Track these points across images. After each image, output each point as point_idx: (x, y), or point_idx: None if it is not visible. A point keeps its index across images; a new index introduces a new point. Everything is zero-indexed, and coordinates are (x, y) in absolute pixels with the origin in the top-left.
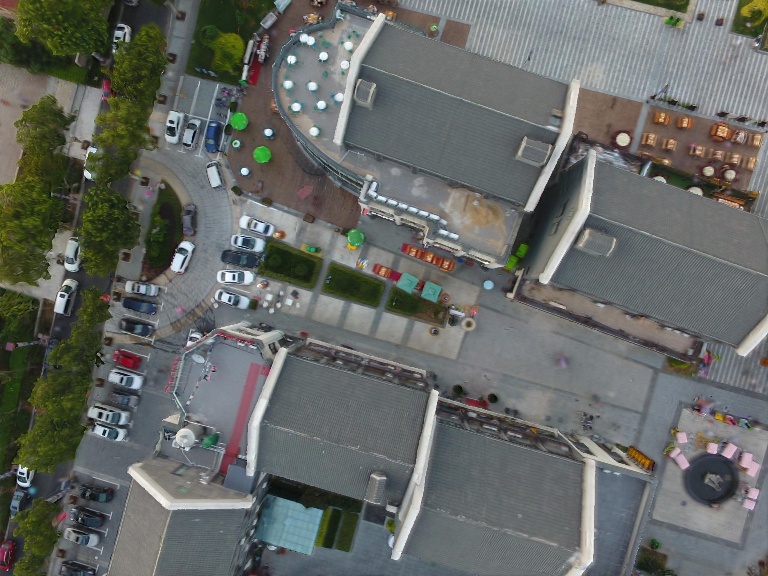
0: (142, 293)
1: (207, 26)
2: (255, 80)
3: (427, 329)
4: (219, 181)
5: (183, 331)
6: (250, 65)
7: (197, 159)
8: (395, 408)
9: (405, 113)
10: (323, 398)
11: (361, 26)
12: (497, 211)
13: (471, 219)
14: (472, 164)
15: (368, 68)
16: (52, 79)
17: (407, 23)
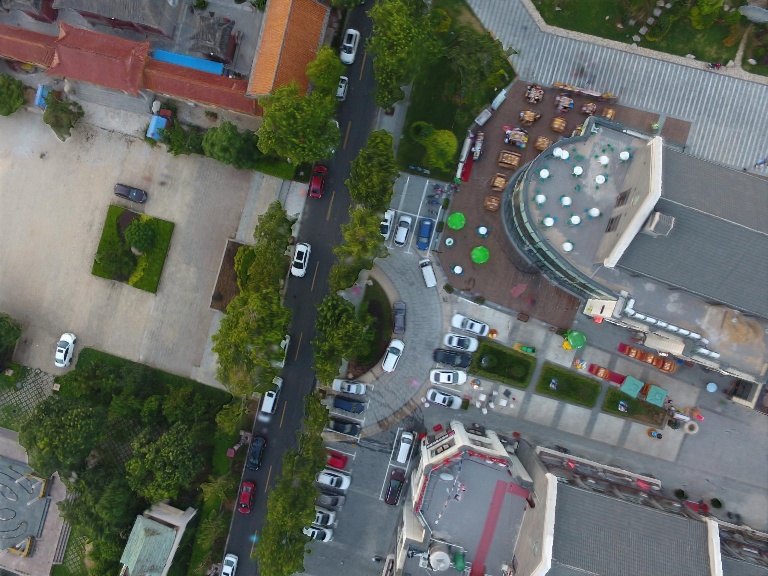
0: (352, 393)
1: (418, 122)
2: (467, 176)
3: (645, 430)
4: (435, 281)
5: (390, 430)
6: (464, 162)
7: (406, 256)
8: (676, 541)
9: (694, 243)
10: (603, 531)
11: (614, 139)
12: (757, 328)
13: (729, 336)
14: (756, 292)
15: (665, 201)
16: (257, 174)
17: (625, 120)
